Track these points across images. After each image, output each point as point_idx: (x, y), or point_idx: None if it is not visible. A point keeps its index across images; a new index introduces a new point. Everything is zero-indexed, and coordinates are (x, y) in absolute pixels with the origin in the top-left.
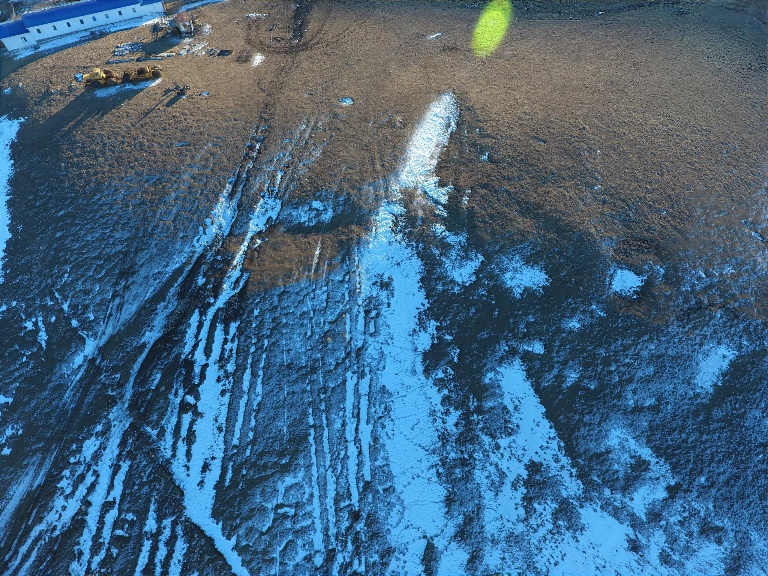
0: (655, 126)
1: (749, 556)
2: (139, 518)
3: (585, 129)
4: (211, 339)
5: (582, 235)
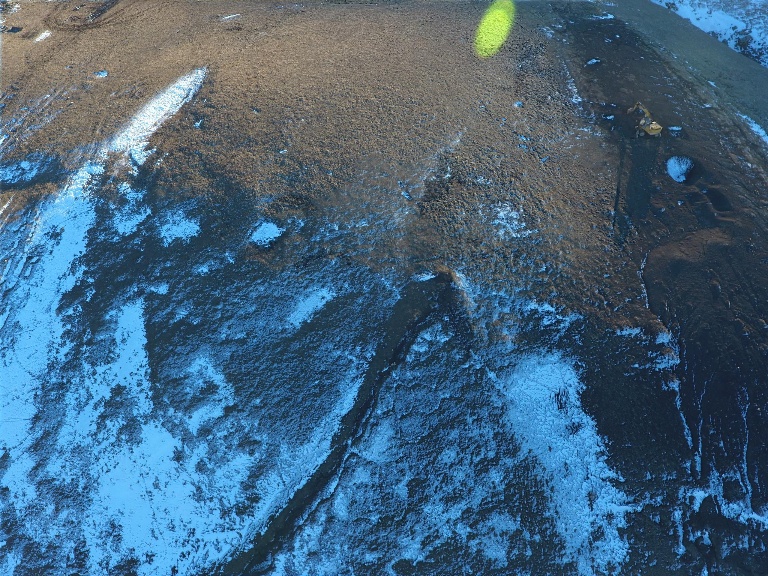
0: (368, 98)
1: (273, 465)
2: None
3: (301, 100)
4: None
5: (245, 192)
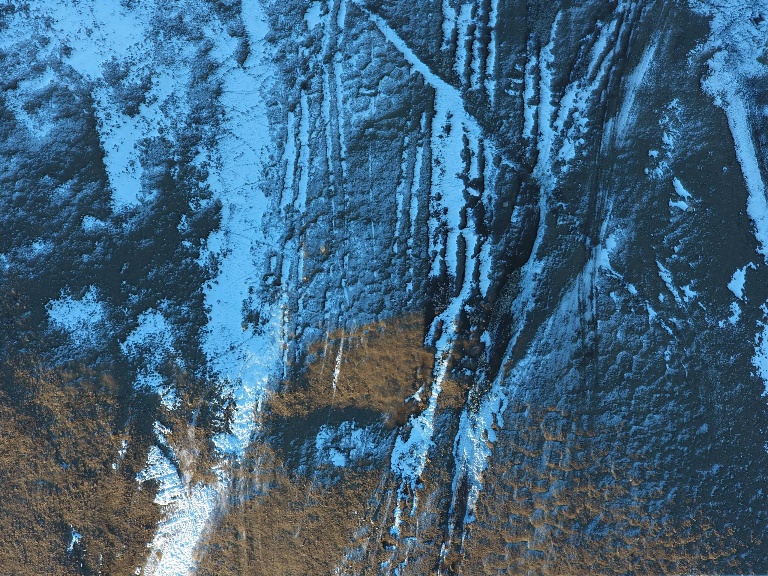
0: None
1: None
2: (502, 91)
3: None
4: (460, 256)
5: None
